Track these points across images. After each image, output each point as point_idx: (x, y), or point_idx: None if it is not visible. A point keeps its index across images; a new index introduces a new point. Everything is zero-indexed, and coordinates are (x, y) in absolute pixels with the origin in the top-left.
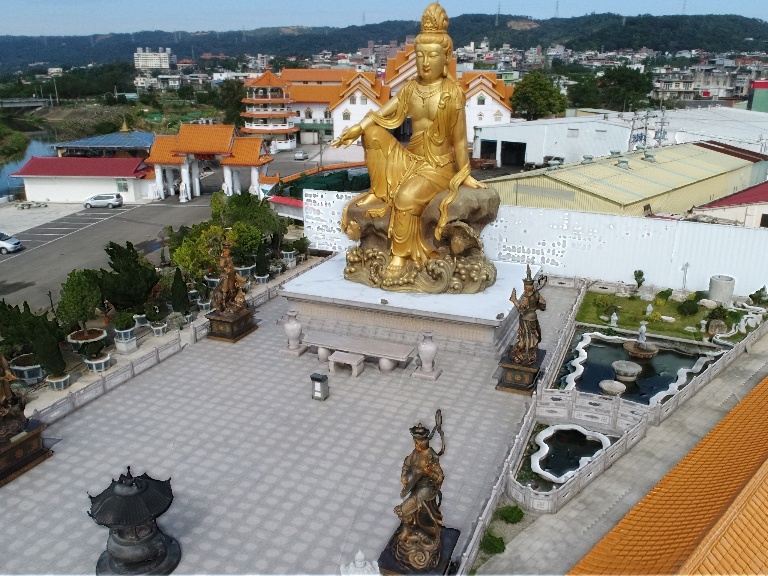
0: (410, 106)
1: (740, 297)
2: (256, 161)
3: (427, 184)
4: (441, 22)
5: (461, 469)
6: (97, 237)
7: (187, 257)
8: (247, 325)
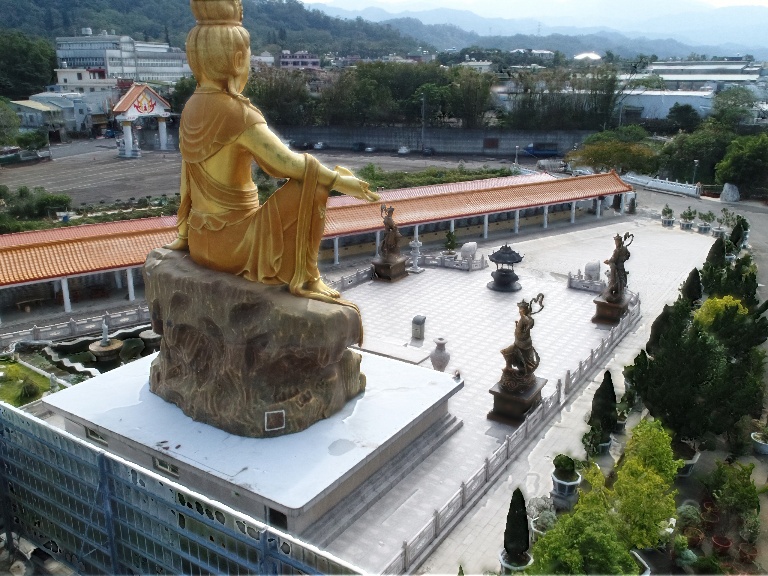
0: None
1: None
2: None
3: None
4: None
5: None
6: None
7: None
8: None
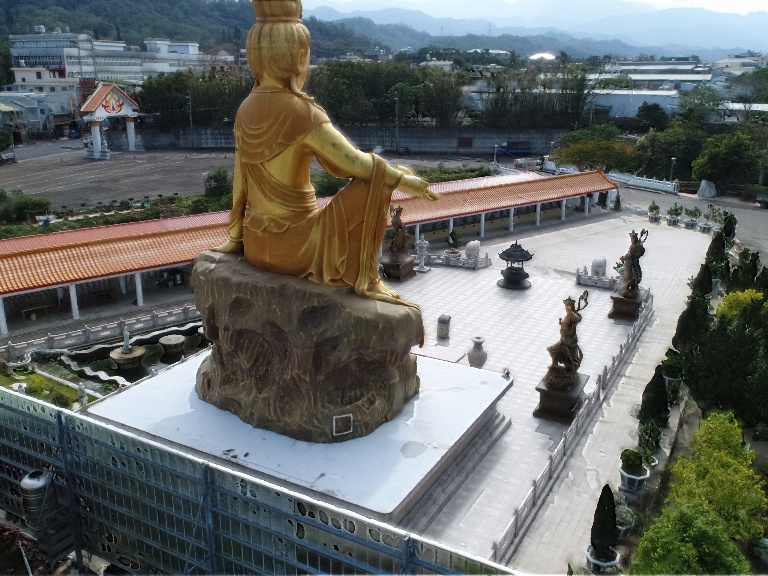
0: None
1: None
2: None
3: None
4: None
5: None
6: None
7: None
8: None
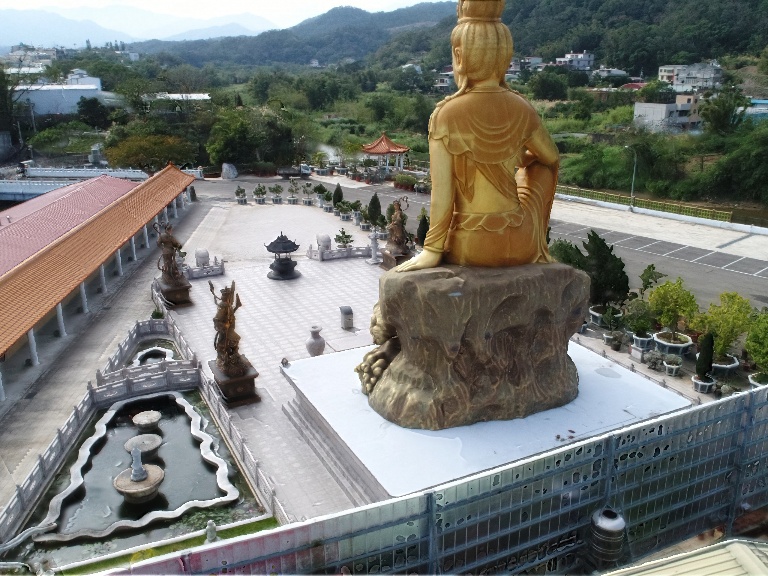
0: None
1: None
2: None
3: None
4: None
5: (208, 333)
6: None
7: None
8: None
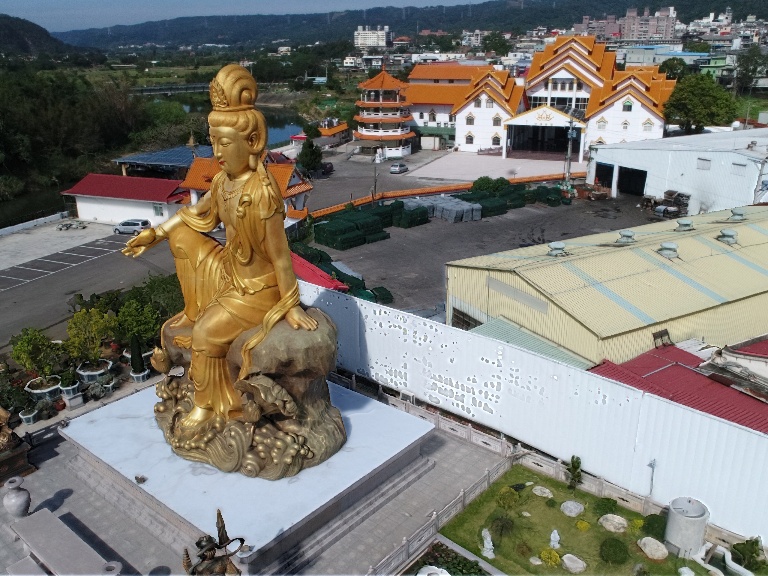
0: (217, 206)
1: (732, 534)
2: (283, 193)
3: (227, 318)
4: (235, 95)
5: None
6: (75, 279)
7: (23, 354)
8: (15, 469)
